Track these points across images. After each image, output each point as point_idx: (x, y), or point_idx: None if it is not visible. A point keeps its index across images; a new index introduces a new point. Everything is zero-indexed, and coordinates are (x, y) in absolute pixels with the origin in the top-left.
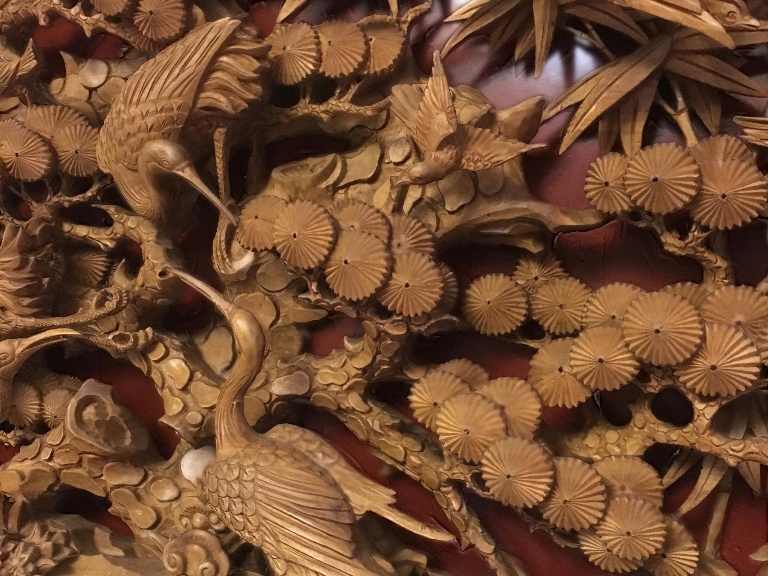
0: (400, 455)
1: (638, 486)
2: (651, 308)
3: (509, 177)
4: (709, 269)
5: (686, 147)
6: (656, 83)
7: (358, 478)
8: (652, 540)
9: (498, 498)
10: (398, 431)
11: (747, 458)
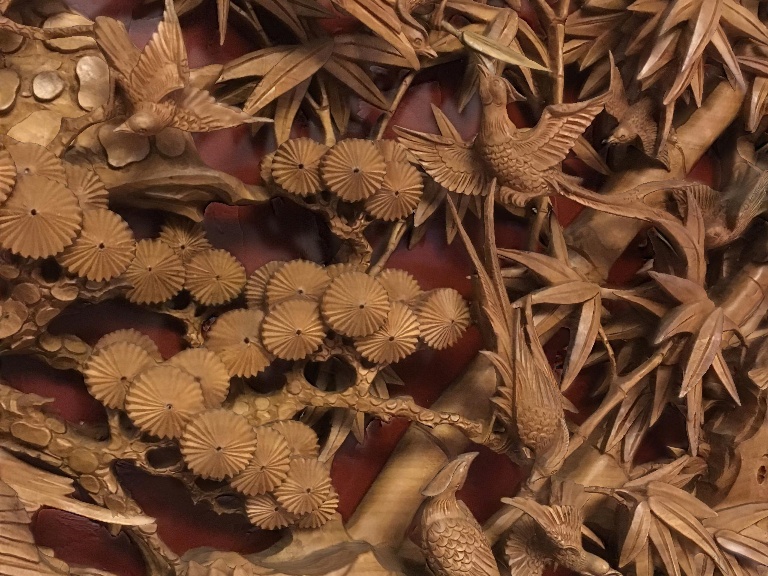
0: (44, 439)
1: (304, 447)
2: (354, 286)
3: (189, 141)
4: (360, 253)
5: (325, 141)
6: (310, 77)
7: (25, 469)
8: (323, 494)
9: (198, 472)
10: (41, 411)
11: (397, 414)
